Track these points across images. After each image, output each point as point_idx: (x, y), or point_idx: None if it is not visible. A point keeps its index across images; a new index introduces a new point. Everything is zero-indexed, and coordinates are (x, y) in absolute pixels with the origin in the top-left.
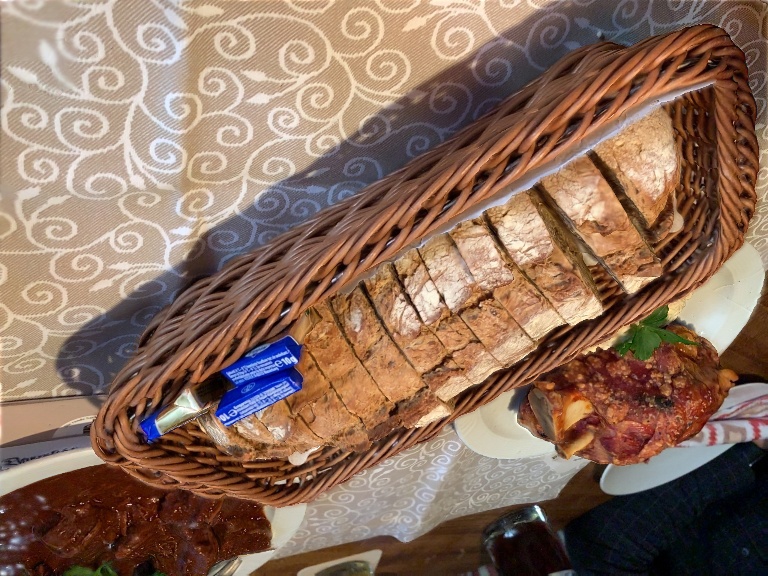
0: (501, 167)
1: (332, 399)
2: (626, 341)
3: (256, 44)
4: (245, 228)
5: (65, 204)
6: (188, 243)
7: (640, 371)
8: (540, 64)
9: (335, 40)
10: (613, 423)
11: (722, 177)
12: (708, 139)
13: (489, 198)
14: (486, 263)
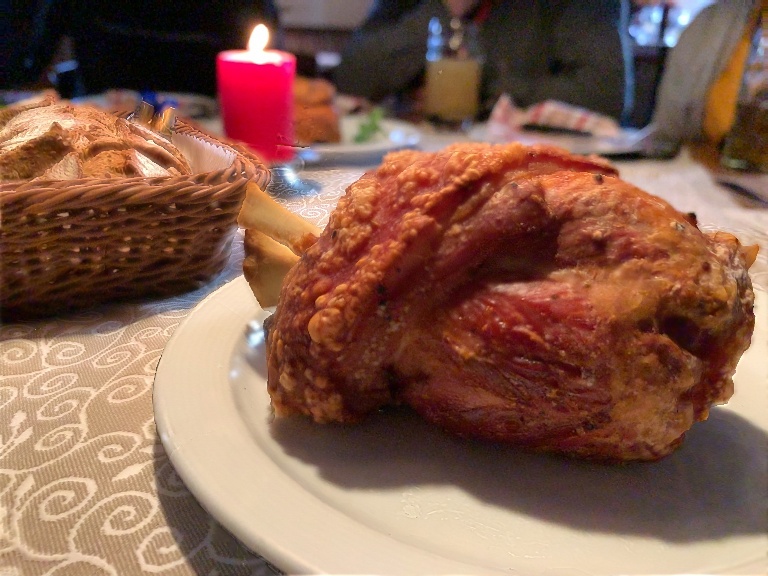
0: None
1: None
2: None
3: None
4: None
5: None
6: None
7: None
8: None
9: None
10: None
11: None
12: None
13: None
14: None
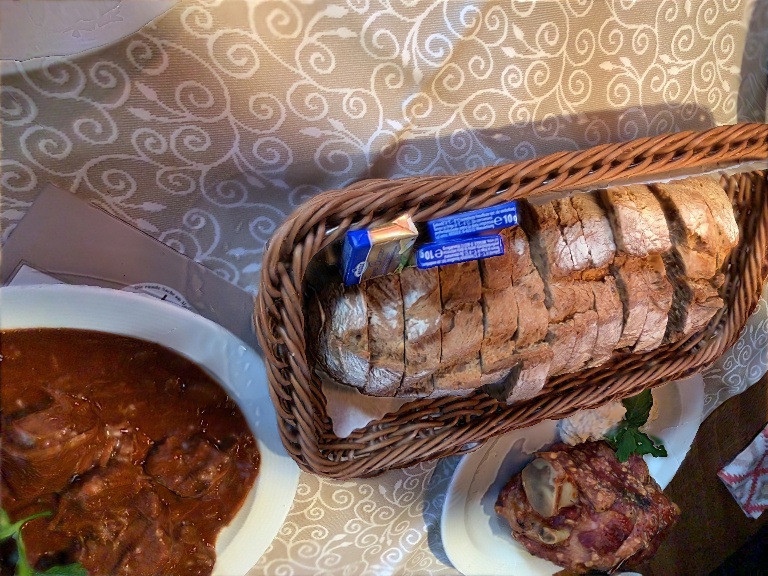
0: (672, 154)
1: (477, 312)
2: (622, 427)
3: (533, 11)
4: (431, 154)
5: (345, 41)
6: (393, 137)
7: (618, 471)
8: None
9: (570, 41)
10: (601, 509)
11: (752, 261)
12: (744, 233)
13: (655, 176)
14: (633, 232)
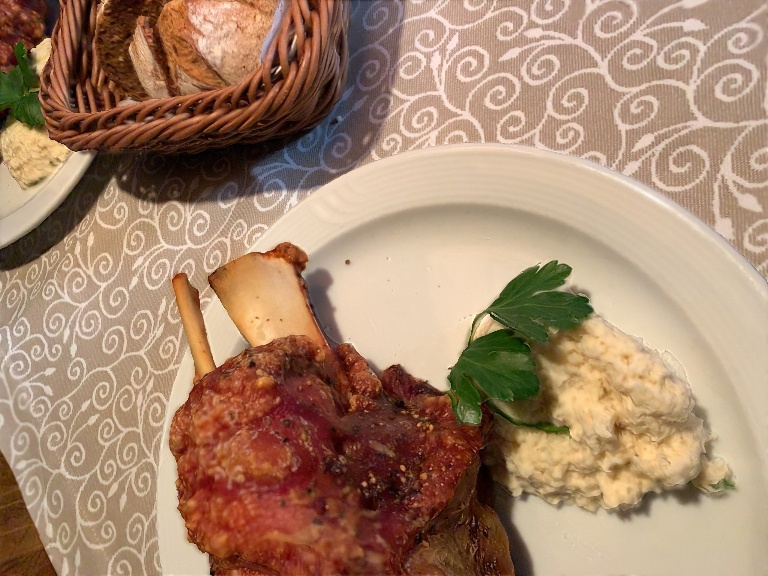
0: None
1: None
2: None
3: None
4: None
5: None
6: None
7: None
8: (354, 59)
9: None
10: None
11: None
12: None
13: None
14: None
